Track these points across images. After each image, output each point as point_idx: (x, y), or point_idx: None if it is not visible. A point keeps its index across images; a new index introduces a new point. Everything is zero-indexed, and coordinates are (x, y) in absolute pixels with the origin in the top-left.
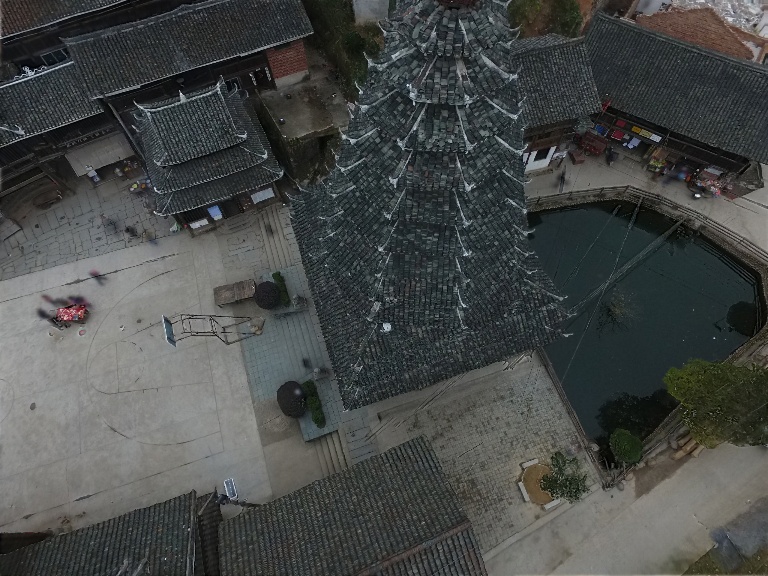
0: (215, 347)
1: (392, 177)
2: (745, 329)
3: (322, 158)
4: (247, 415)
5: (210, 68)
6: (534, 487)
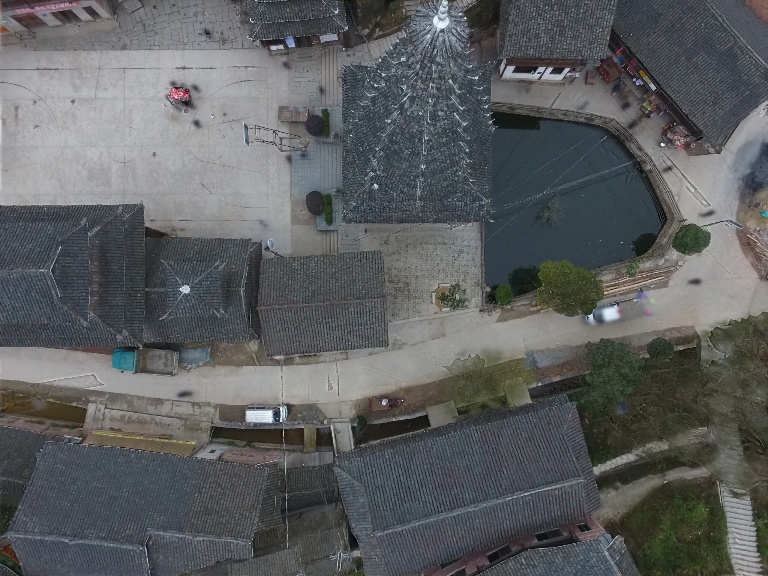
0: (273, 150)
1: (388, 119)
2: (640, 252)
3: (385, 12)
4: (286, 203)
5: None
6: None
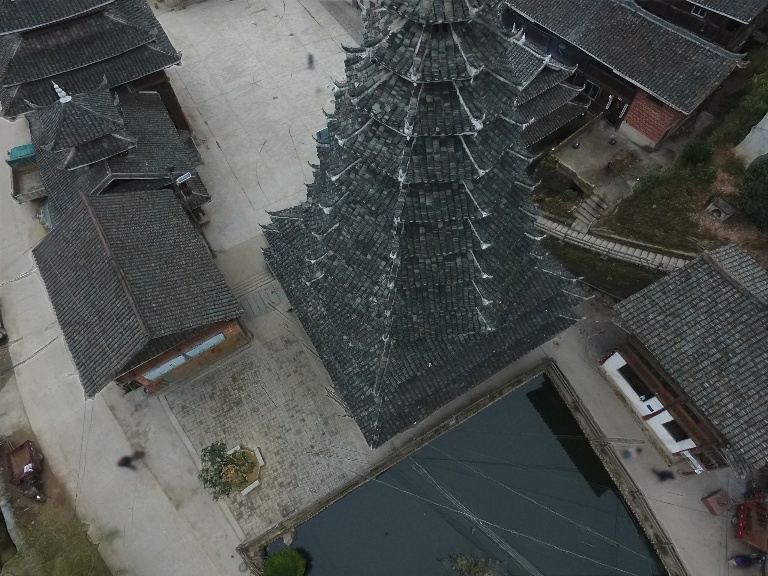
0: None
1: None
2: None
3: None
4: None
5: (590, 60)
6: None
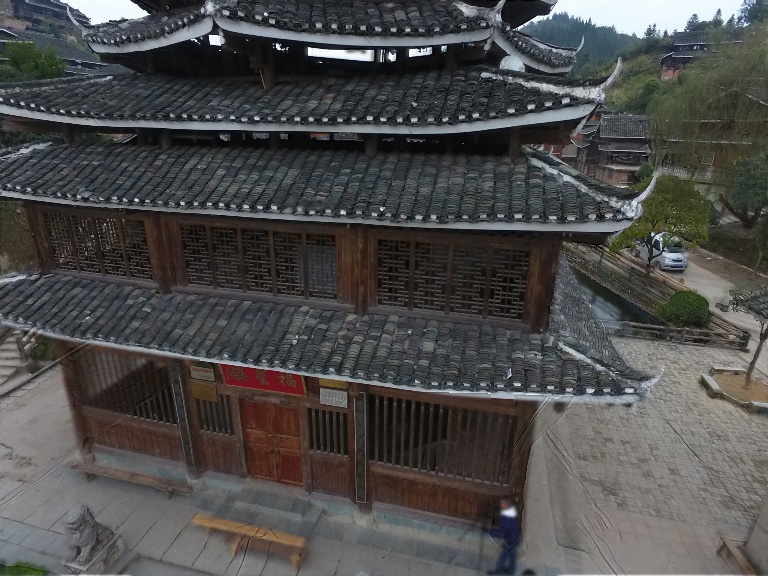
0: None
1: None
2: None
3: None
4: None
5: None
6: (759, 395)
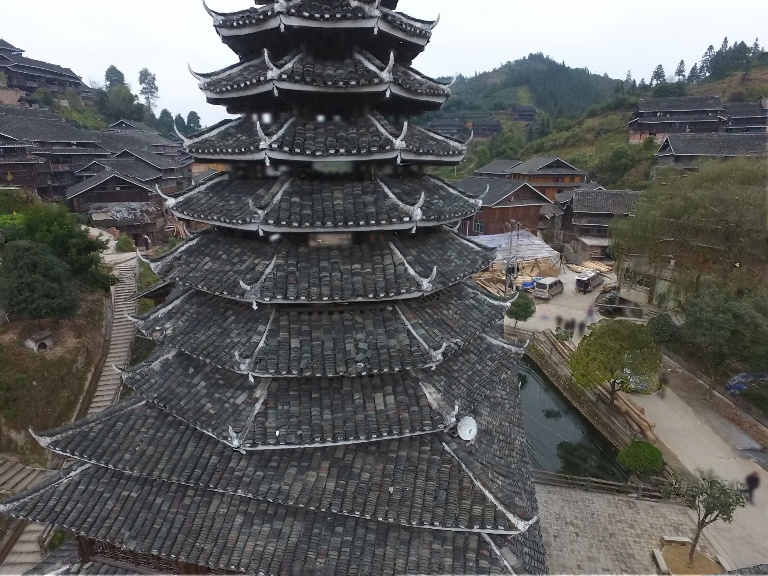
0: None
1: None
2: None
3: None
4: None
5: None
6: None
